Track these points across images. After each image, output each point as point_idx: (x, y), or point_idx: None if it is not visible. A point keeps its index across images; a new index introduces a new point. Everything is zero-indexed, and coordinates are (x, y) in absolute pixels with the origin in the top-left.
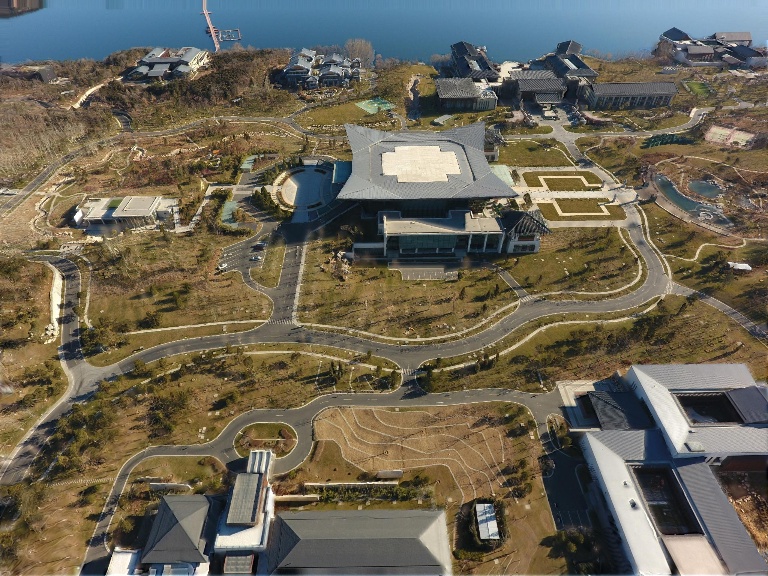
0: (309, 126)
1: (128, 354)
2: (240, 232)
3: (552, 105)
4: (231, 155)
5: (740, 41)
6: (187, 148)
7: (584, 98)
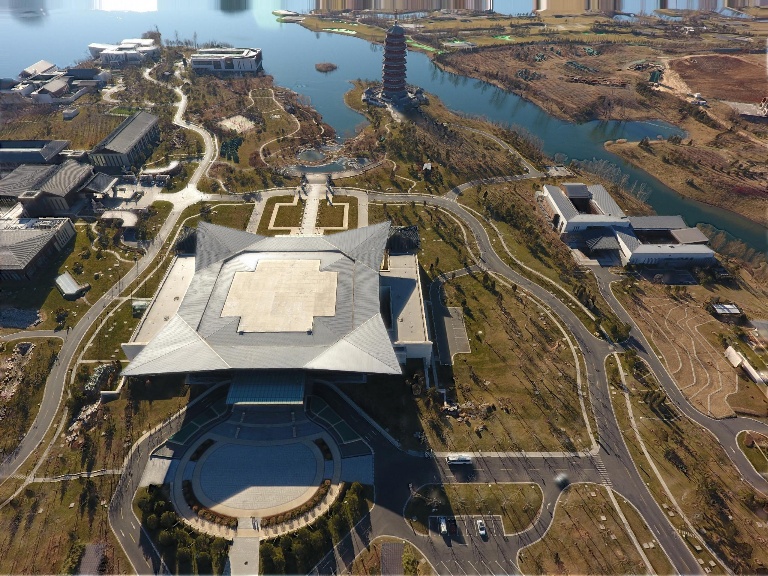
0: None
1: None
2: (416, 573)
3: (112, 187)
4: None
5: (51, 68)
6: None
7: (100, 167)
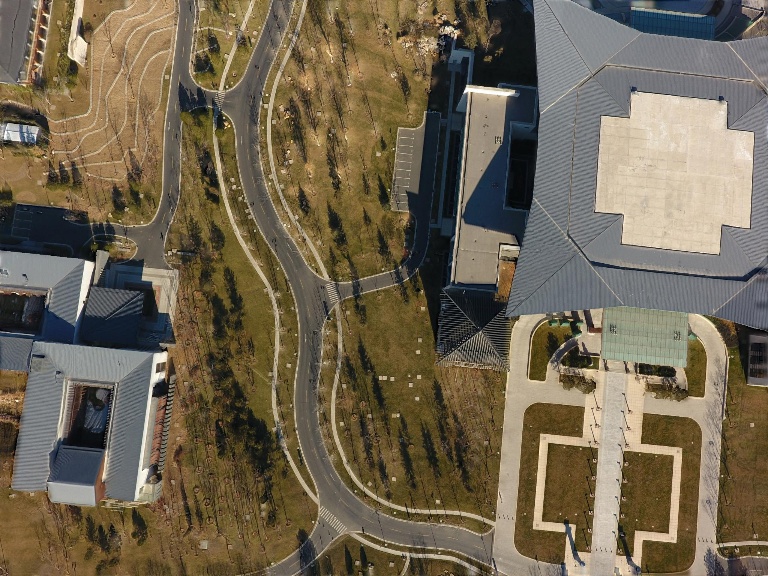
0: None
1: None
2: None
3: None
4: None
5: None
6: None
7: None
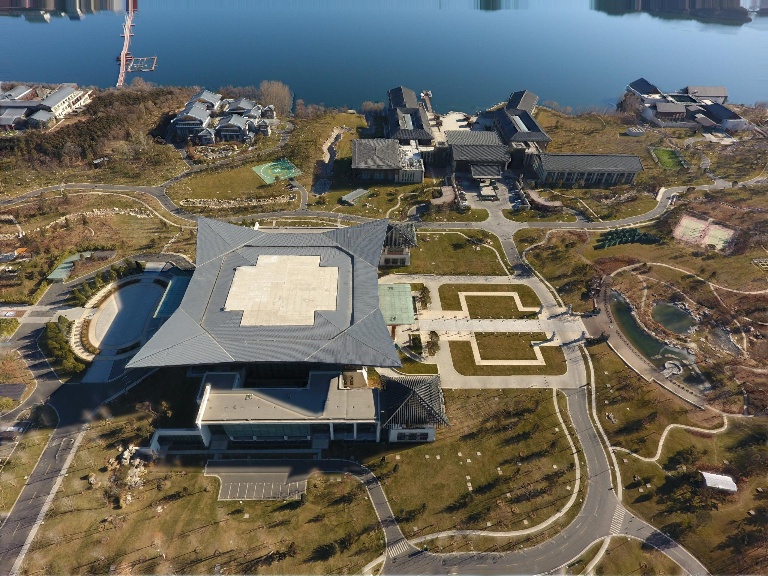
0: (183, 200)
1: None
2: None
3: (491, 180)
4: (46, 253)
5: (715, 97)
6: (4, 233)
7: (532, 169)
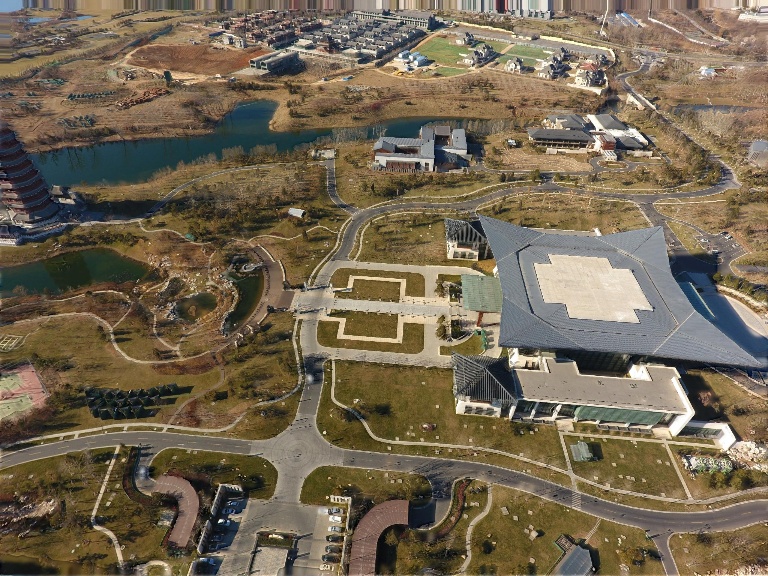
0: None
1: (726, 192)
2: None
3: None
4: None
5: None
6: None
7: None
